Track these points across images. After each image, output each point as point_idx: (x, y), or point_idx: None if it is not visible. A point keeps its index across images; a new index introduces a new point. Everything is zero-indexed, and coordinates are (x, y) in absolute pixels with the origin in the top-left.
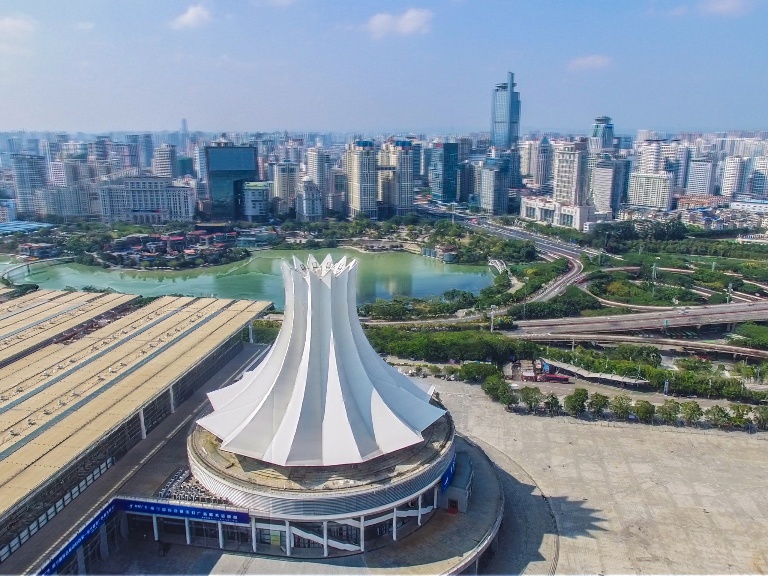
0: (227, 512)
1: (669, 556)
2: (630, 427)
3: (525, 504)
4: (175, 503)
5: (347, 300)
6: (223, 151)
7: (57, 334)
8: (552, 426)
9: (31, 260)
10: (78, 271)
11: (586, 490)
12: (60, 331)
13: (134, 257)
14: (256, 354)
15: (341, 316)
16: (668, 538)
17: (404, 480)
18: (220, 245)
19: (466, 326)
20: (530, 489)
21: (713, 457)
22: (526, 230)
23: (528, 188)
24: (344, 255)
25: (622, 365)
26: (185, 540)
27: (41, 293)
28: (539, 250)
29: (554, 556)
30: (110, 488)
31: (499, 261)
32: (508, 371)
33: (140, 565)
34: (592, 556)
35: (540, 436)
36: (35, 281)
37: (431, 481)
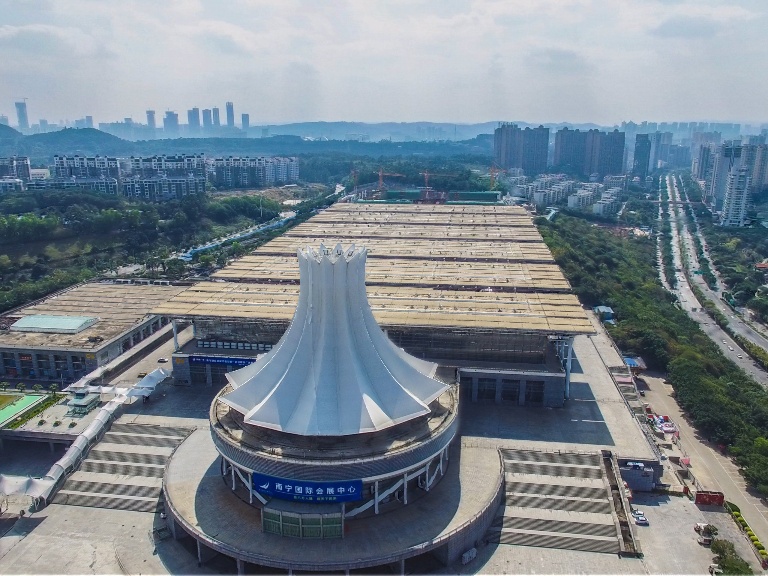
0: None
1: None
2: None
3: None
4: None
5: None
6: None
7: (446, 284)
8: None
9: None
10: None
11: None
12: None
13: None
14: (532, 370)
15: None
16: None
17: None
18: None
19: None
20: None
21: None
22: None
23: None
24: None
25: None
26: None
27: (547, 266)
28: None
29: None
30: None
31: None
32: None
33: None
34: None
35: None
36: None
37: None
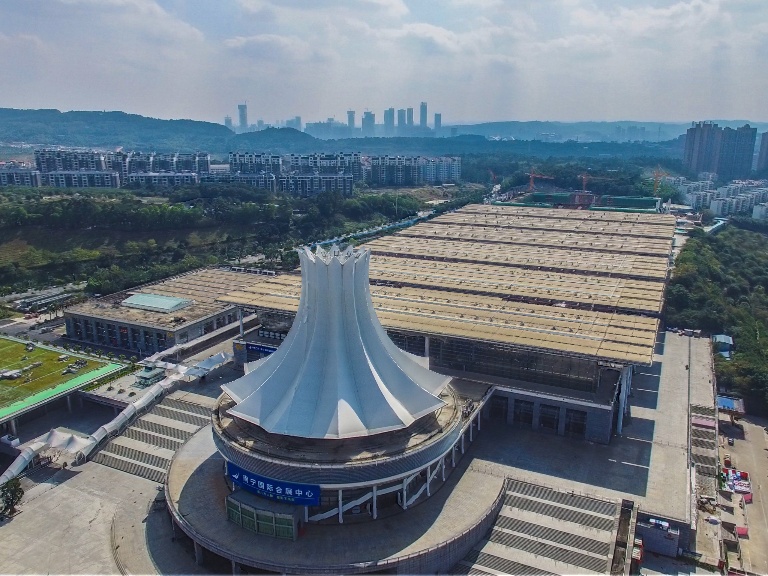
0: None
1: None
2: None
3: None
4: None
5: None
6: None
7: (518, 295)
8: None
9: None
10: None
11: None
12: (526, 295)
13: None
14: (575, 398)
15: None
16: None
17: None
18: None
19: None
20: None
21: None
22: None
23: None
24: None
25: None
26: None
27: (650, 283)
28: None
29: None
30: None
31: None
32: None
33: None
34: None
35: None
36: None
37: None
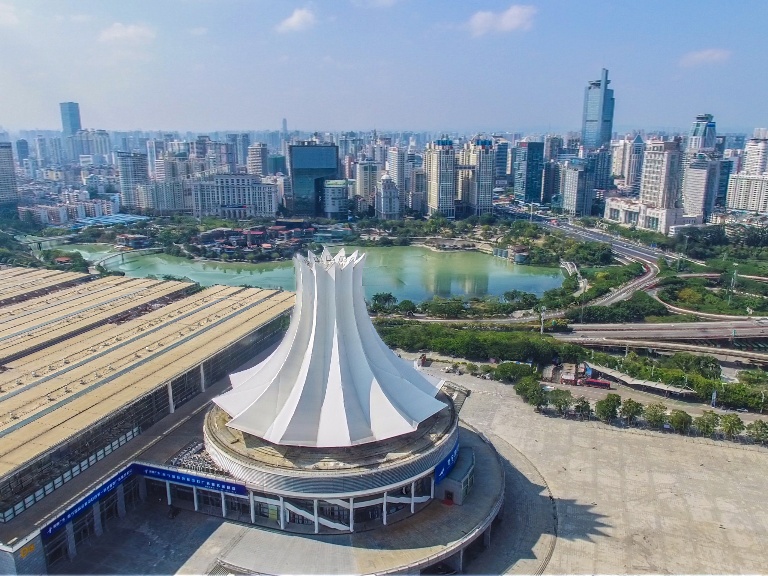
0: (227, 483)
1: (669, 567)
2: (662, 436)
3: (530, 503)
4: (183, 471)
5: (354, 292)
6: (306, 150)
7: (113, 315)
8: (579, 430)
9: (126, 250)
10: (166, 261)
11: (598, 495)
12: (116, 313)
13: (216, 249)
14: None
15: (346, 307)
16: (673, 550)
17: (392, 467)
18: (296, 240)
19: (518, 327)
20: (539, 489)
21: (746, 473)
22: (607, 232)
23: (613, 189)
24: (416, 253)
25: (669, 373)
26: (193, 506)
27: (111, 278)
28: (616, 253)
29: (546, 556)
30: (131, 454)
31: (570, 263)
32: (548, 373)
33: (150, 525)
34: (586, 559)
35: (564, 439)
36: (127, 269)
37: (423, 470)
